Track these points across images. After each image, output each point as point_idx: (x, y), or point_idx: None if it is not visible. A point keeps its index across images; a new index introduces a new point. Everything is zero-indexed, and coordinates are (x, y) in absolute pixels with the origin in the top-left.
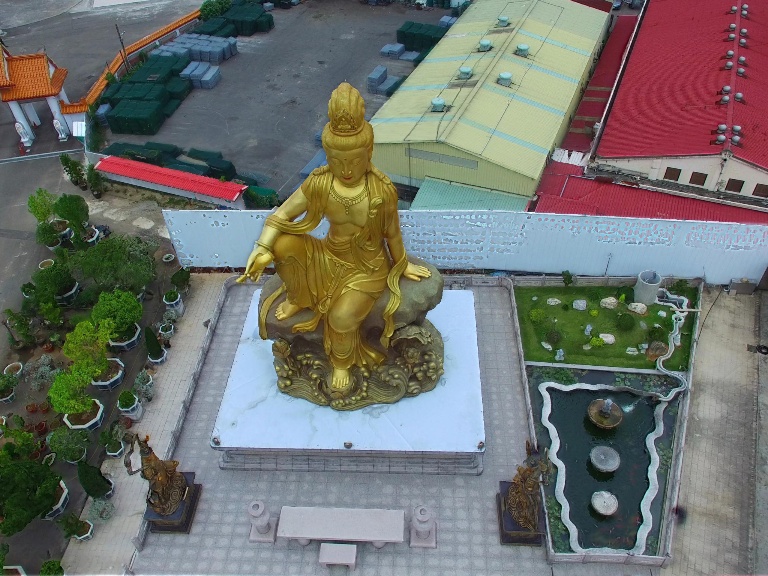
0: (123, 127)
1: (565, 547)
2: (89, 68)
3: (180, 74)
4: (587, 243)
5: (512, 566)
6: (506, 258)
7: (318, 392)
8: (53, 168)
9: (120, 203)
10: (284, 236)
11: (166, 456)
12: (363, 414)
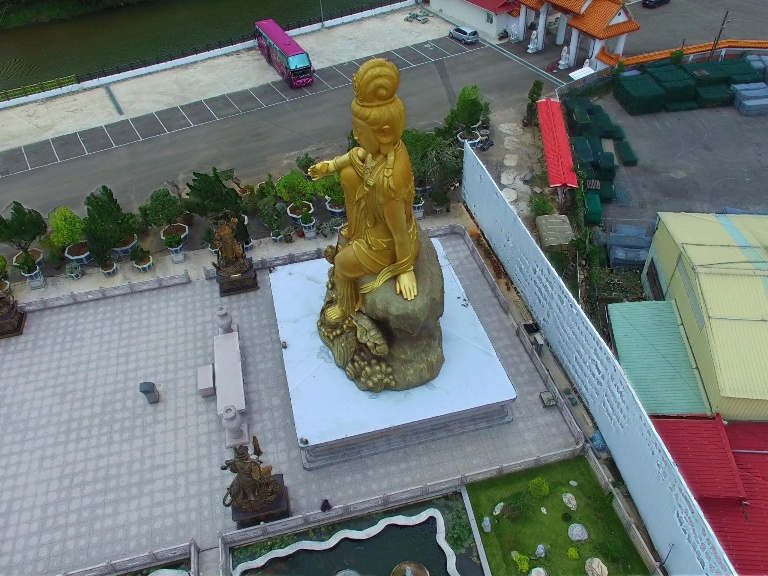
0: (619, 94)
1: (242, 558)
2: (699, 43)
3: (732, 85)
4: (666, 502)
5: (217, 511)
6: (609, 427)
7: (325, 306)
8: (543, 90)
9: (527, 138)
10: (352, 167)
11: (272, 259)
12: (320, 347)
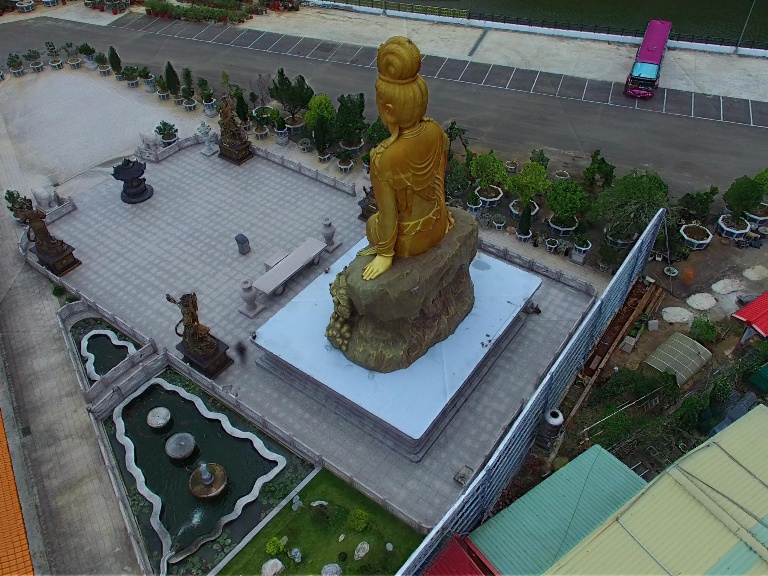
0: None
1: (167, 377)
2: None
3: None
4: None
5: None
6: None
7: None
8: None
9: None
10: None
11: None
12: None
